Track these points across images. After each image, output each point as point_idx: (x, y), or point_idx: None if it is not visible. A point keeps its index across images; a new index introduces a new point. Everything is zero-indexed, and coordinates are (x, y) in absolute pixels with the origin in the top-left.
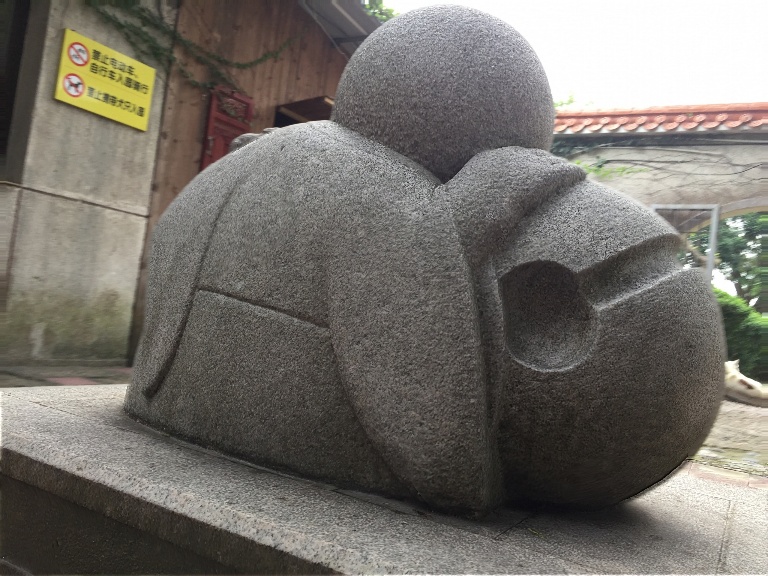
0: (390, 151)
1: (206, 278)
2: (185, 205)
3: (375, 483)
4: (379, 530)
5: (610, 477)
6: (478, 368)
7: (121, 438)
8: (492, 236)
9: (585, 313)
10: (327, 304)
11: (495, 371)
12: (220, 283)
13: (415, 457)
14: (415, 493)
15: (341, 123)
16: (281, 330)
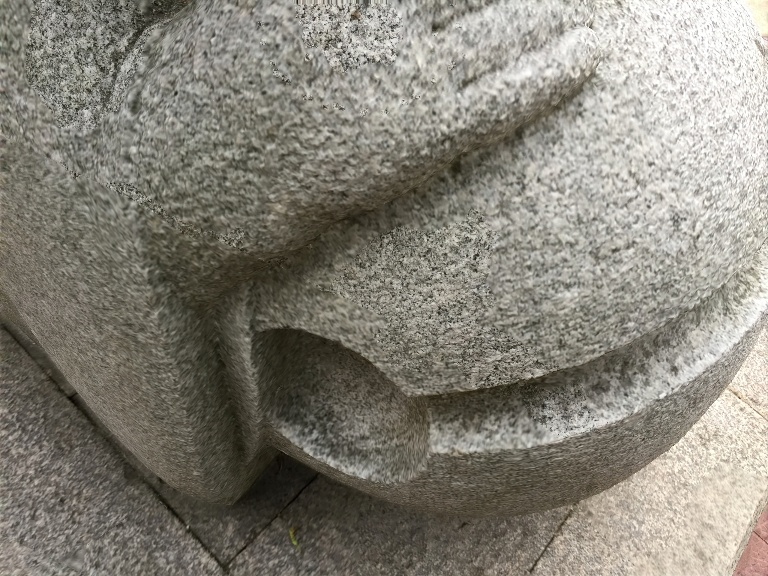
0: None
1: None
2: None
3: None
4: (72, 557)
5: None
6: (206, 445)
7: None
8: (240, 270)
9: None
10: None
11: (247, 431)
12: None
13: None
14: None
15: None
16: None
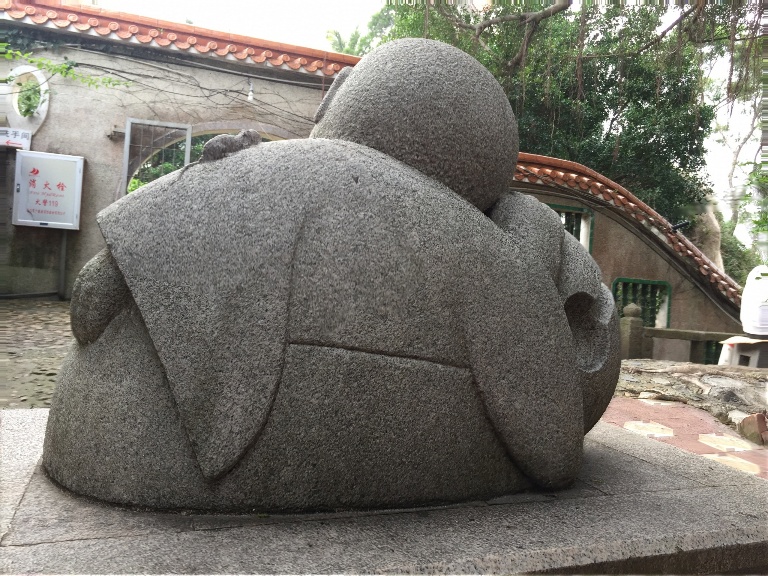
0: (457, 194)
1: (305, 331)
2: (202, 233)
3: (507, 486)
4: (592, 519)
5: None
6: None
7: (257, 539)
8: None
9: (591, 325)
10: (467, 347)
11: None
12: (337, 336)
13: (554, 457)
14: (547, 483)
15: (389, 153)
16: (428, 378)
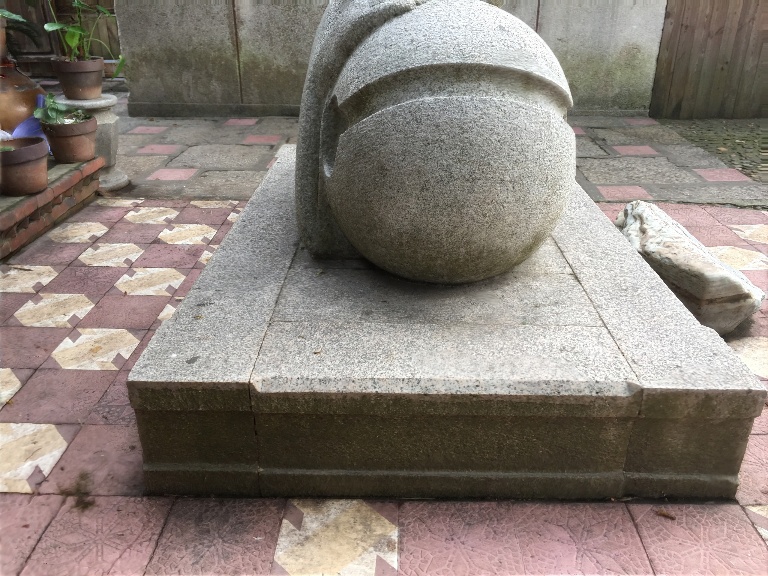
0: None
1: None
2: None
3: None
4: None
5: (372, 256)
6: (305, 168)
7: None
8: (327, 75)
9: None
10: None
11: None
12: None
13: None
14: None
15: None
16: None
